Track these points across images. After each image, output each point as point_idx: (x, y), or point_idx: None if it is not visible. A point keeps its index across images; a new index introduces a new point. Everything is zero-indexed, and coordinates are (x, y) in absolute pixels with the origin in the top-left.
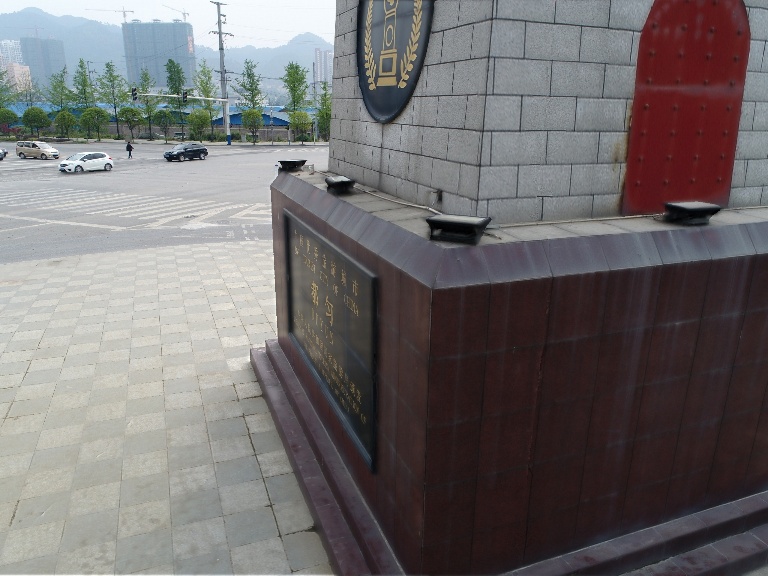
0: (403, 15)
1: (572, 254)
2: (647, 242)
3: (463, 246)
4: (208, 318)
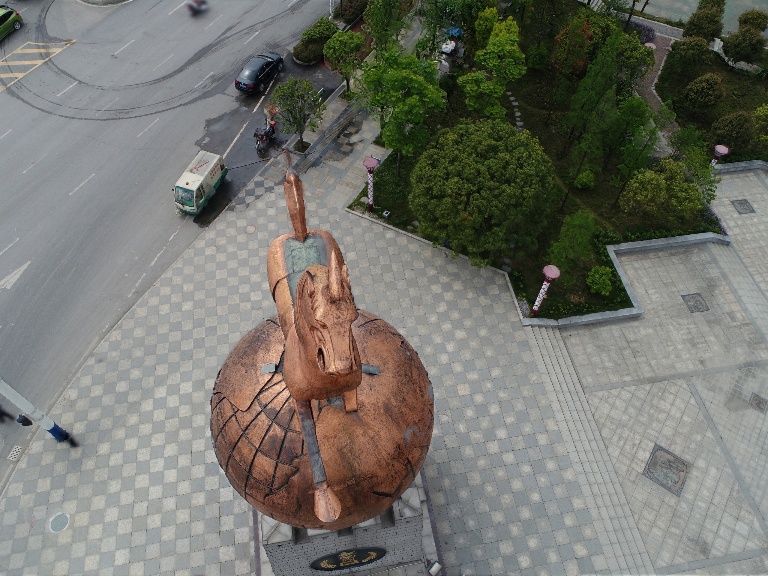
0: None
1: (436, 540)
2: (430, 515)
3: (440, 570)
4: None
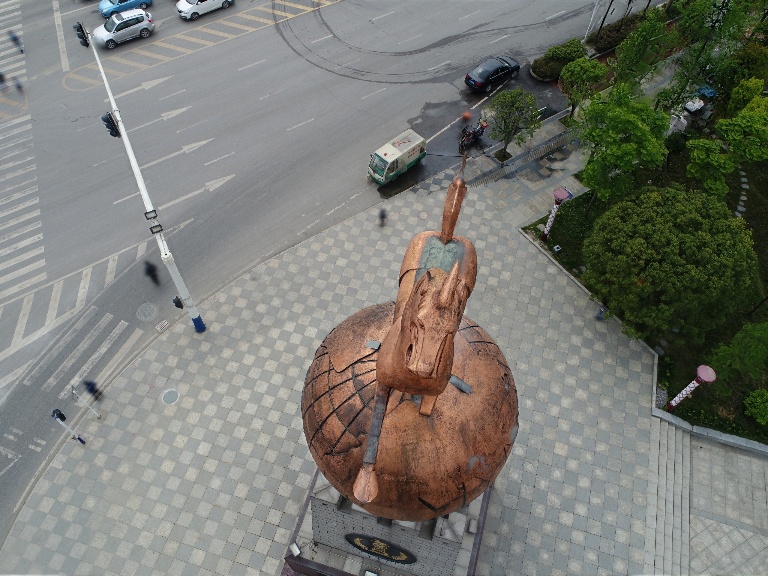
0: (392, 552)
1: (469, 575)
2: None
3: None
4: (210, 574)
